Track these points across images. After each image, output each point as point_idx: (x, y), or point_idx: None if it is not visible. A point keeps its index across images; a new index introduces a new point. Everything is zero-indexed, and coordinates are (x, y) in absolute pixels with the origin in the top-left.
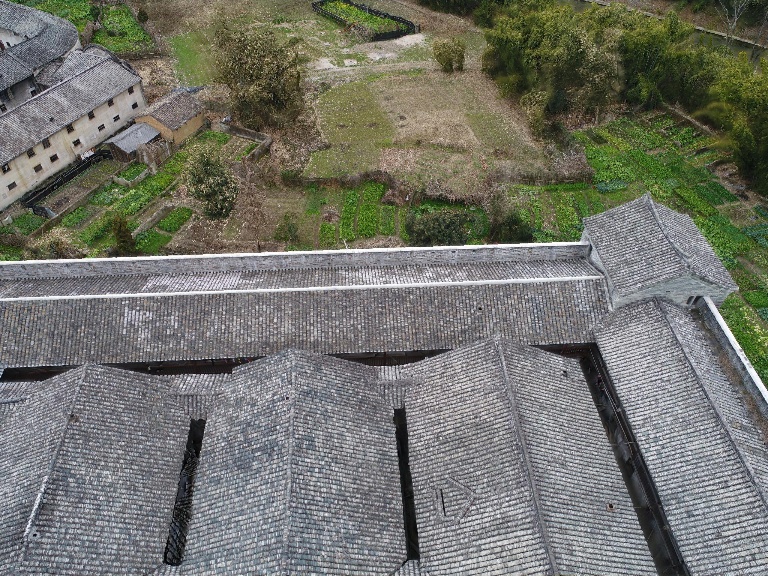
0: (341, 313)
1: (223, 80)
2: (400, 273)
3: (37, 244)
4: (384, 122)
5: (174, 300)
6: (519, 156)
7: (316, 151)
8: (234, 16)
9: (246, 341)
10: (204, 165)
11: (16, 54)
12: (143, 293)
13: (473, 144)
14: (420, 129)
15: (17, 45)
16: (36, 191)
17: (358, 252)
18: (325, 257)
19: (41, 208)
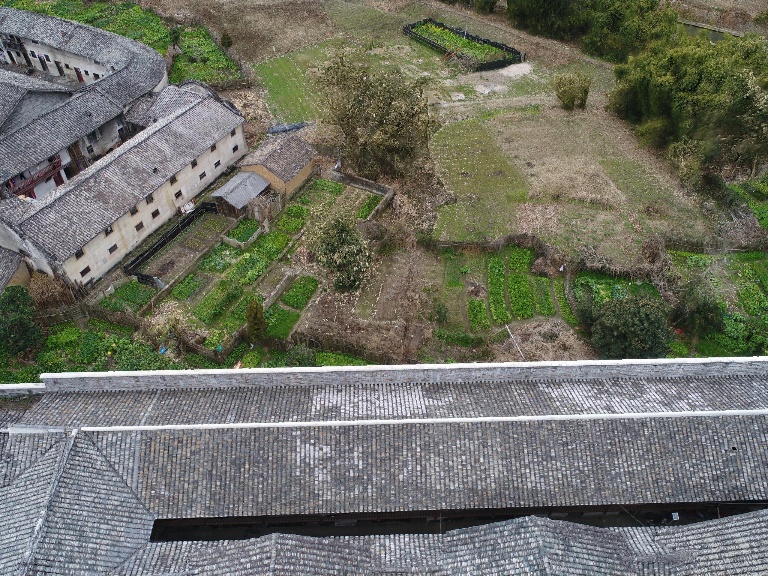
0: (562, 451)
1: (333, 121)
2: (617, 392)
3: (153, 327)
4: (511, 170)
5: (356, 431)
6: (674, 215)
7: (442, 205)
8: (320, 40)
9: (448, 487)
10: (338, 231)
11: (105, 89)
12: (318, 421)
13: (618, 199)
14: (553, 179)
15: (105, 79)
16: (139, 255)
17: (566, 365)
18: (524, 370)
19: (148, 277)
